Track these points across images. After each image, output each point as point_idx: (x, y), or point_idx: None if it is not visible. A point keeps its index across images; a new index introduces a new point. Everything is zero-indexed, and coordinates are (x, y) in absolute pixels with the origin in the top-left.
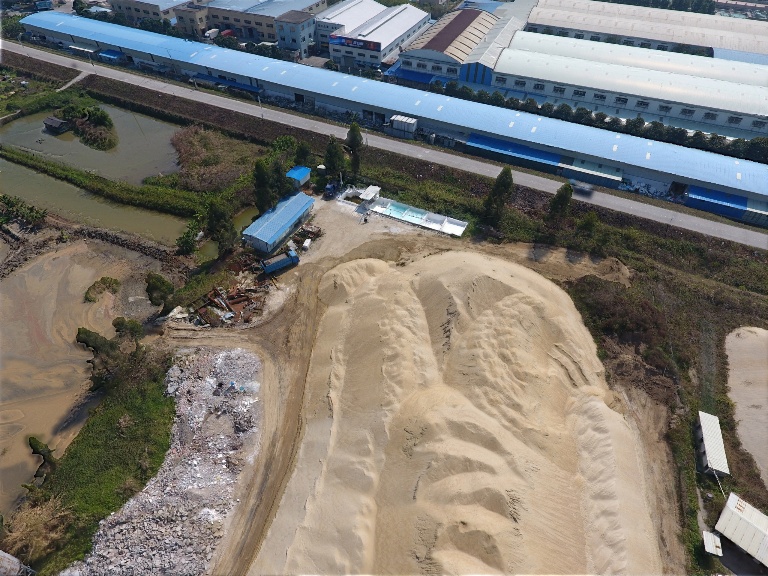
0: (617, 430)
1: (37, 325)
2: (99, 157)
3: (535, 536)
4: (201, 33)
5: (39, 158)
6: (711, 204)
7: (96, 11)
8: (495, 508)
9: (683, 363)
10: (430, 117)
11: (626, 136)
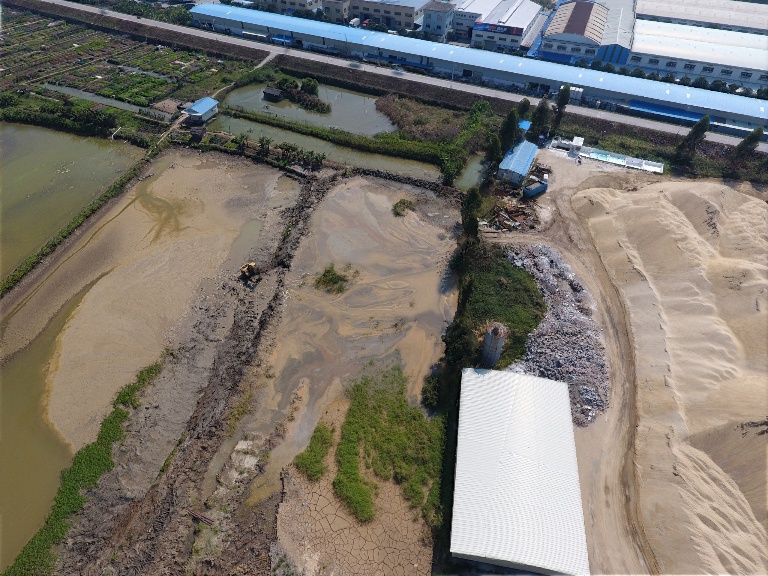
0: None
1: (372, 230)
2: (317, 120)
3: None
4: None
5: (281, 118)
6: None
7: (242, 3)
8: None
9: None
10: (595, 87)
11: (765, 101)
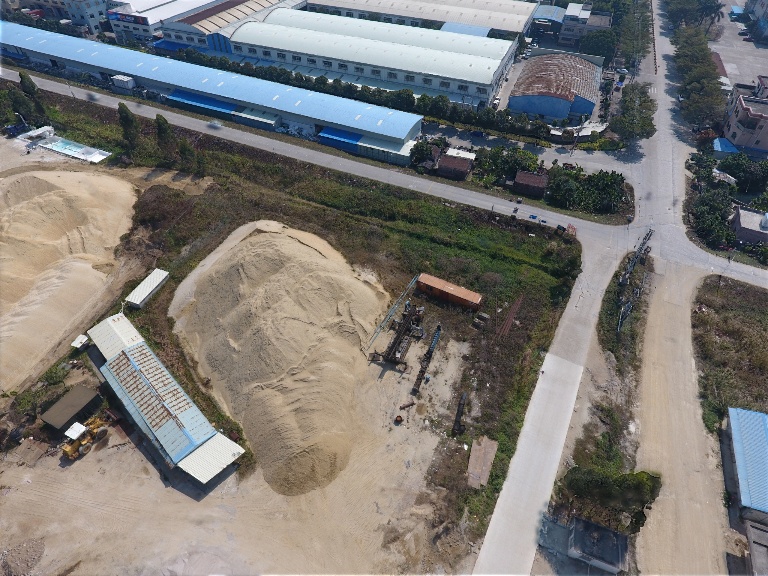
0: (80, 280)
1: None
2: None
3: None
4: None
5: None
6: (334, 140)
7: None
8: None
9: (180, 241)
10: (142, 76)
11: (297, 89)
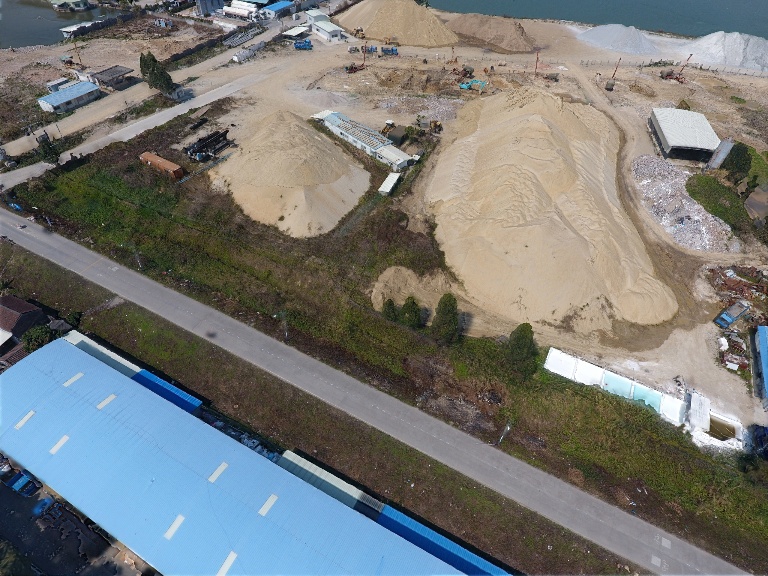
0: None
1: None
2: None
3: None
4: None
5: None
6: None
7: None
8: None
9: None
10: None
11: (203, 571)
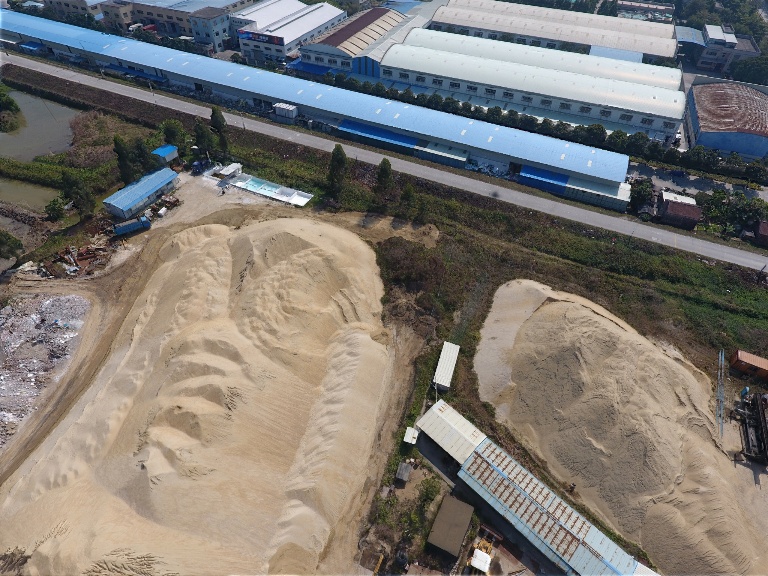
0: (370, 355)
1: None
2: (2, 139)
3: (248, 422)
4: (126, 27)
5: None
6: (538, 181)
7: (29, 5)
8: (214, 399)
9: (450, 306)
10: (308, 104)
11: (479, 122)
